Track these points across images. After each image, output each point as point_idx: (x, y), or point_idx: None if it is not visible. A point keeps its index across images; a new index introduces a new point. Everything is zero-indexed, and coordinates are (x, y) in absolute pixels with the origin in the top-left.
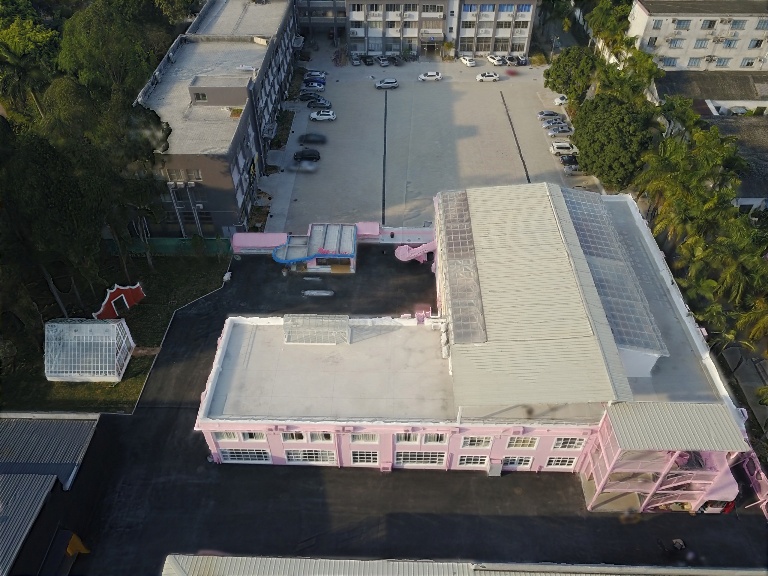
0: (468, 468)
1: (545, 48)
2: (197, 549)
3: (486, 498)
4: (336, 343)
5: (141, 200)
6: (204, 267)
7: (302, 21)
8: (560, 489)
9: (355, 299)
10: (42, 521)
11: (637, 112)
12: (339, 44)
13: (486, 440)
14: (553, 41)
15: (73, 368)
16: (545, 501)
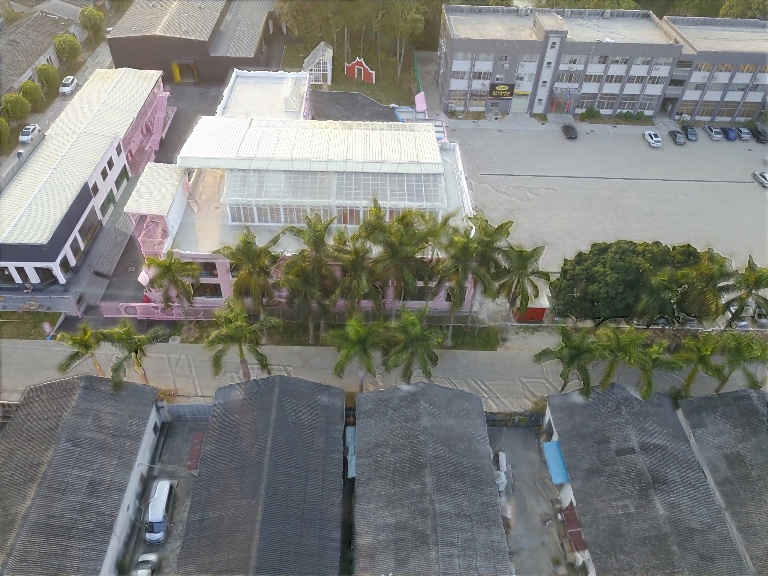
0: None
1: None
2: (190, 108)
3: None
4: None
5: (364, 4)
6: (404, 99)
7: None
8: None
9: None
10: (189, 45)
11: None
12: None
13: None
14: None
15: None
16: None
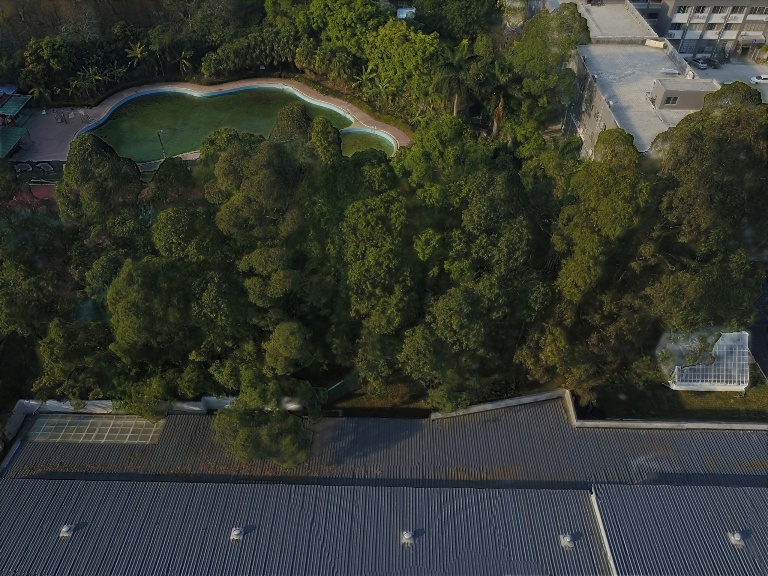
0: None
1: None
2: None
3: None
4: None
5: None
6: None
7: None
8: None
9: None
10: None
11: None
12: None
13: None
14: None
15: (705, 377)
16: None
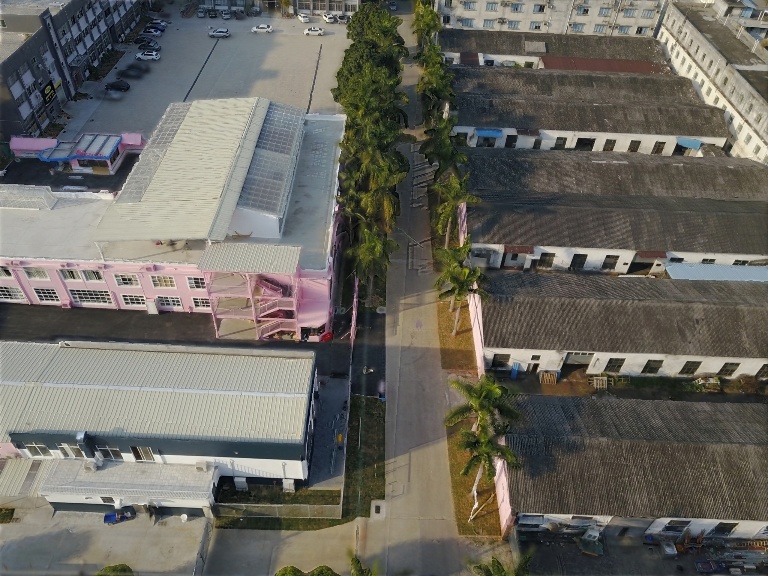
0: (135, 308)
1: None
2: None
3: (139, 328)
4: (39, 209)
5: None
6: None
7: None
8: (202, 324)
9: None
10: None
11: None
12: None
13: (134, 279)
14: (379, 2)
15: None
16: (186, 331)
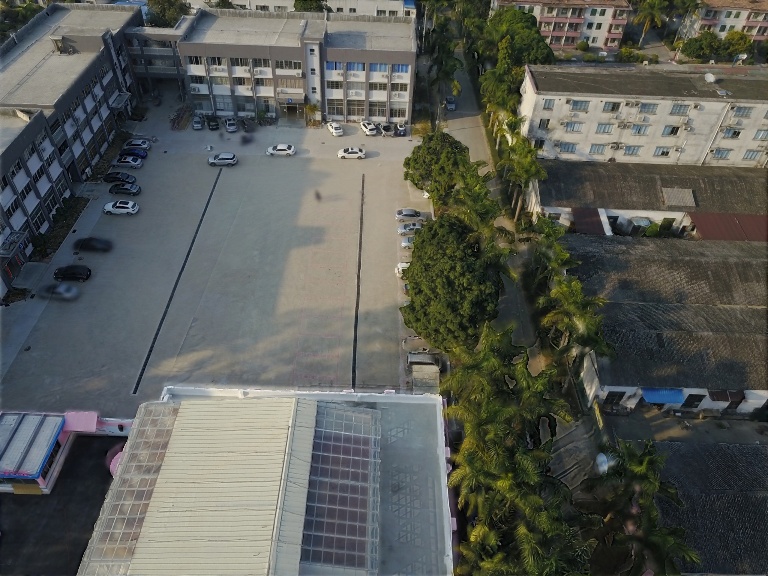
0: None
1: (436, 111)
2: None
3: None
4: None
5: None
6: None
7: (138, 70)
8: None
9: (28, 548)
10: None
11: (484, 249)
12: (187, 98)
13: None
14: (437, 109)
15: None
16: None
